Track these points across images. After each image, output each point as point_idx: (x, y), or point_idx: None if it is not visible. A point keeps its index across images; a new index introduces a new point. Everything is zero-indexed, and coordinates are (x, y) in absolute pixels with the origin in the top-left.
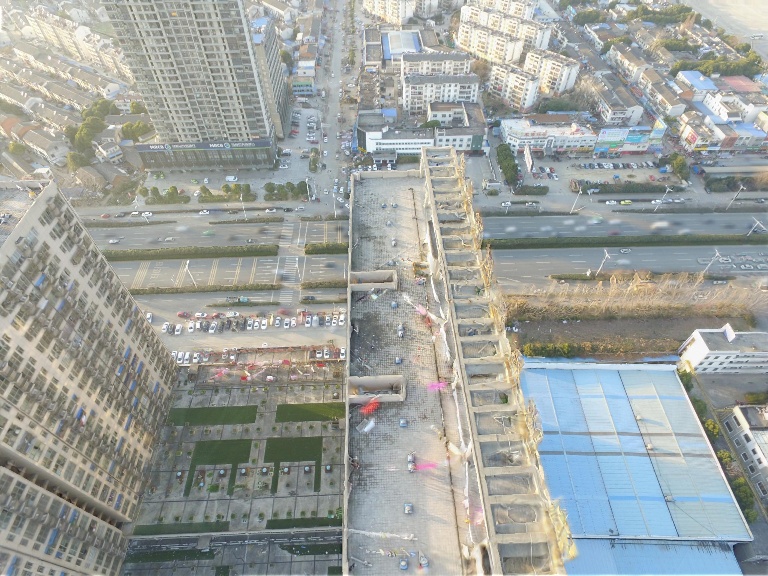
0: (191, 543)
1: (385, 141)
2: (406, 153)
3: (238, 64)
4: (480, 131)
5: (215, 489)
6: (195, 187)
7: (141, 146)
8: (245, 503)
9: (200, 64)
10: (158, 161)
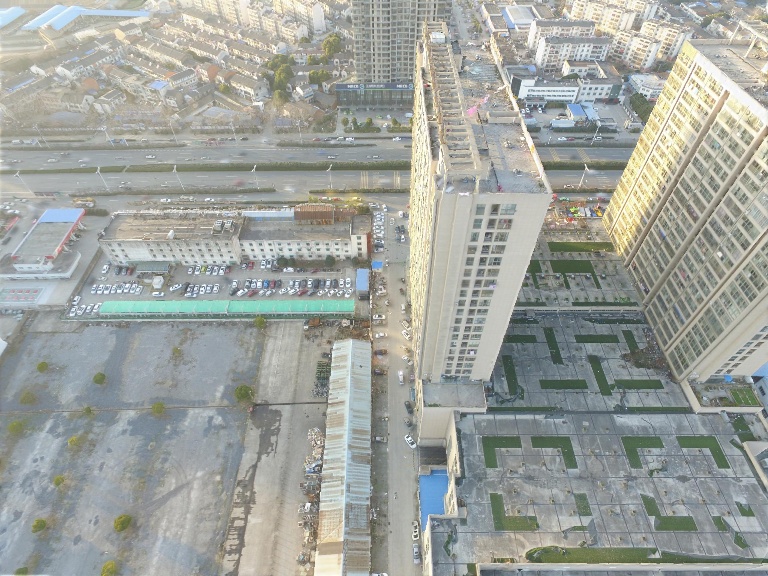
0: (520, 314)
1: (537, 88)
2: (552, 100)
3: (441, 13)
4: (618, 82)
5: (526, 285)
6: (381, 121)
7: (340, 85)
8: (551, 293)
9: (410, 13)
10: (349, 99)
